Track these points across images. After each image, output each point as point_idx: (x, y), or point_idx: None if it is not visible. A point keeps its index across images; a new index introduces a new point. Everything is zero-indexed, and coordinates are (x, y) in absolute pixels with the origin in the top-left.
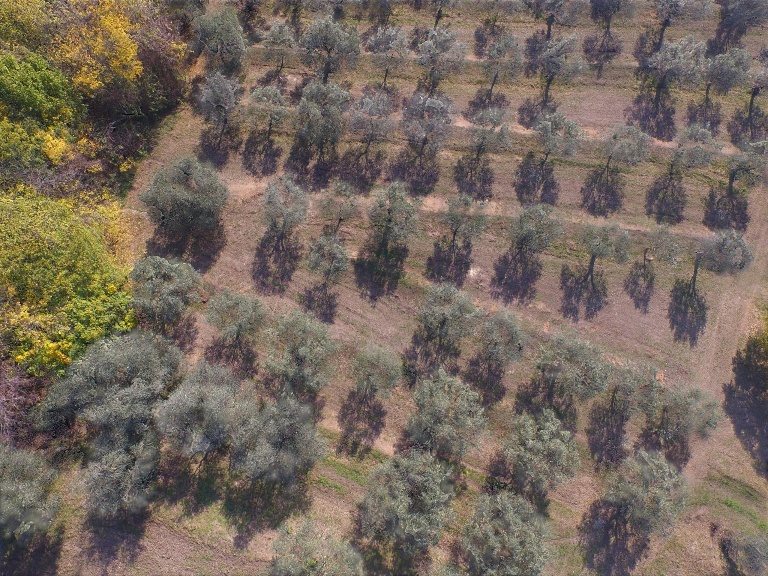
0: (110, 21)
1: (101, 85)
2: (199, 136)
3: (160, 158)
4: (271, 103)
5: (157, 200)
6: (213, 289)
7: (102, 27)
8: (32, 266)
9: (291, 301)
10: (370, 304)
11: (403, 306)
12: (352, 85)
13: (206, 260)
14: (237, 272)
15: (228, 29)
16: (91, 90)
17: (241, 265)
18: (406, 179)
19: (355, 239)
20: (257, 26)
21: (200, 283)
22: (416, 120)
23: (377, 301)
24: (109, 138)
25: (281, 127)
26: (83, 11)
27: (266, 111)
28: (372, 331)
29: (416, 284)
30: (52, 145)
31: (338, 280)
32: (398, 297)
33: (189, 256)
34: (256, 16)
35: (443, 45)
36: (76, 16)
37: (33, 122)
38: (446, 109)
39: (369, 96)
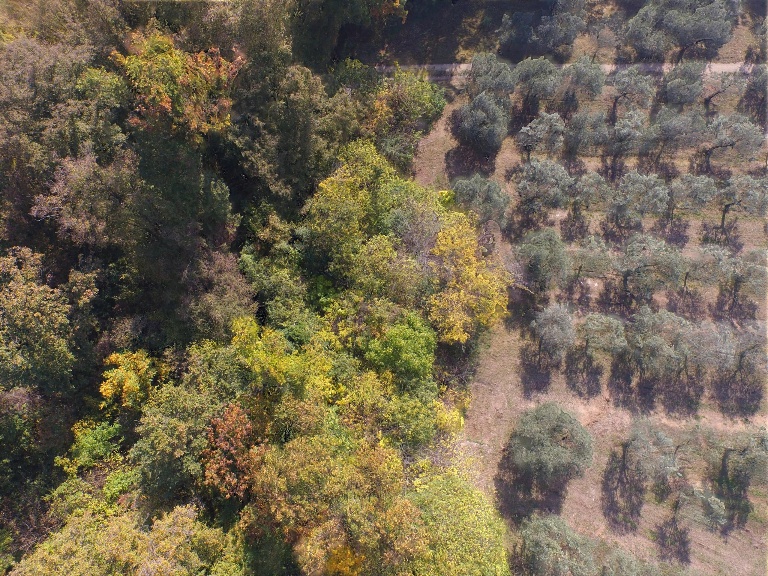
0: (472, 270)
1: (468, 337)
2: (518, 354)
3: (485, 380)
4: (582, 315)
5: (546, 465)
6: (574, 533)
7: (467, 278)
8: (481, 573)
9: (644, 539)
10: (721, 539)
11: (756, 541)
12: (654, 290)
13: (554, 497)
14: (588, 509)
15: (564, 259)
16: (456, 341)
17: (590, 501)
18: (730, 396)
19: (694, 467)
20: (540, 220)
21: (560, 527)
22: (731, 332)
23: (728, 535)
24: (459, 378)
25: (598, 342)
26: (452, 265)
27: (582, 326)
28: (728, 569)
29: (767, 518)
30: (437, 409)
31: (686, 514)
32: (749, 531)
33: (537, 493)
34: (536, 209)
35: (735, 242)
36: (444, 269)
37: (424, 391)
38: (753, 315)
39: (674, 302)
